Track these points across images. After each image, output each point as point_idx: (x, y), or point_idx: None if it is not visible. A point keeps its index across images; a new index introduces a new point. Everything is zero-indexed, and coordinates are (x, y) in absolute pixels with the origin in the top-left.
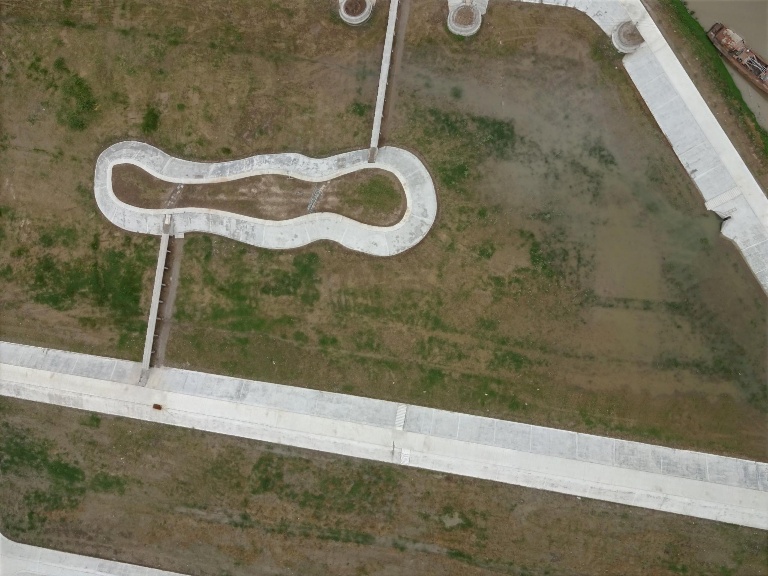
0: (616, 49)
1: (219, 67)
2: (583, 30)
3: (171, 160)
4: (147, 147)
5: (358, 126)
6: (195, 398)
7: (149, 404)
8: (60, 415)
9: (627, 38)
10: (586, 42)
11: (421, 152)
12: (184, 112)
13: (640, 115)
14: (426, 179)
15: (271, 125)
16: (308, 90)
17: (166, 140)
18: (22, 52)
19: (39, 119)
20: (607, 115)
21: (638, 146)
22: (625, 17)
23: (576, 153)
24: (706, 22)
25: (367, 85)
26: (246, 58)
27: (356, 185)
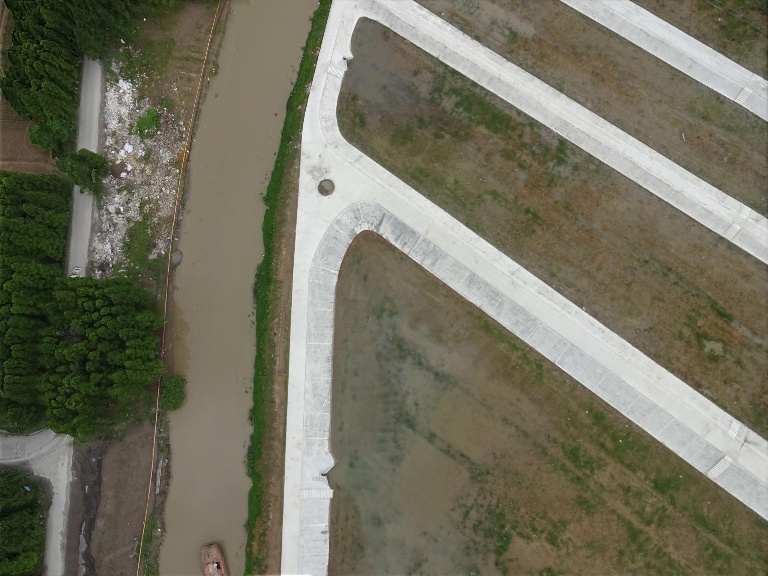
0: None
1: None
2: None
3: None
4: None
5: None
6: None
7: None
8: None
9: None
10: None
11: None
12: None
13: None
14: None
15: None
16: None
17: None
18: None
19: None
20: None
21: None
22: None
23: None
24: None
25: None
26: None
27: None
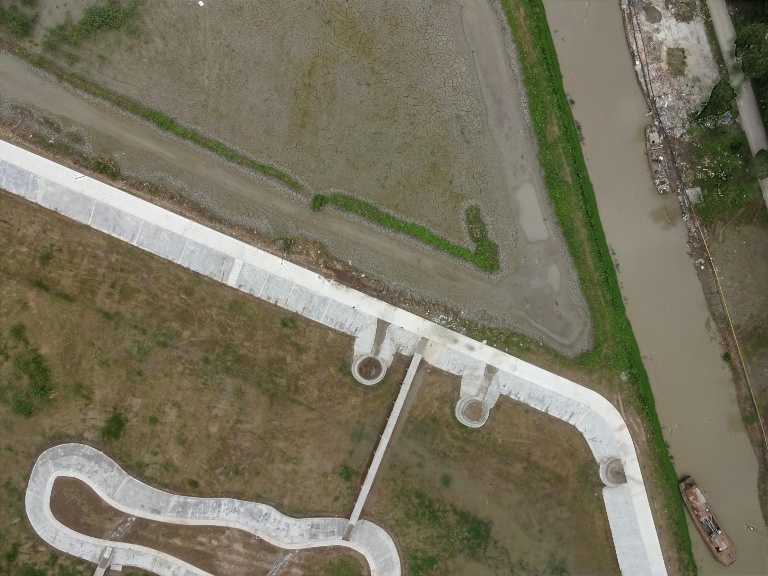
0: (600, 479)
1: (208, 386)
2: (576, 450)
3: (127, 480)
4: (103, 458)
5: (341, 491)
6: None
7: None
8: None
9: (613, 475)
10: (576, 462)
11: (397, 534)
12: (155, 427)
13: (604, 546)
14: (395, 565)
15: (249, 466)
16: (298, 438)
17: (127, 456)
18: None
19: None
20: (576, 538)
21: (595, 575)
22: (616, 454)
23: (540, 569)
24: (680, 469)
25: (360, 449)
26: (240, 385)
27: (324, 561)
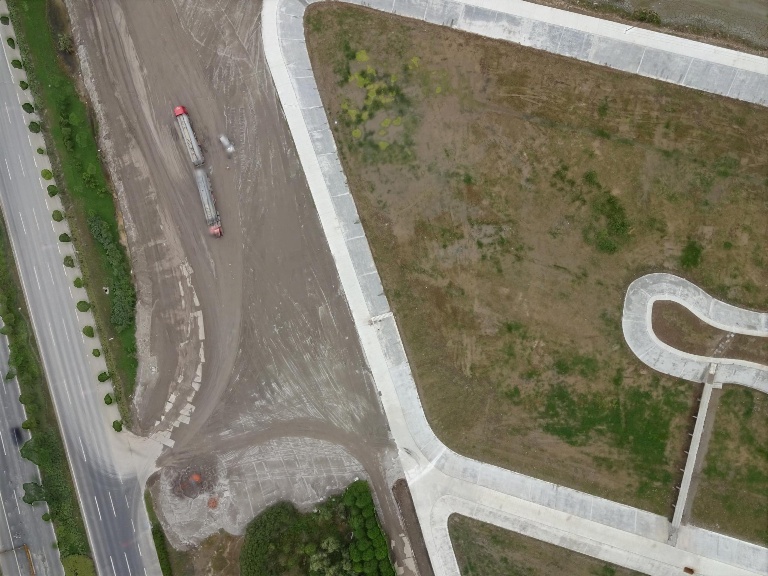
0: None
1: None
2: None
3: (714, 302)
4: (687, 284)
5: None
6: (733, 568)
7: (679, 566)
8: (568, 559)
9: None
10: None
11: None
12: (730, 251)
13: None
14: None
15: None
16: None
17: (710, 279)
18: (547, 157)
19: (562, 233)
20: None
21: None
22: None
23: None
24: None
25: None
26: None
27: None
